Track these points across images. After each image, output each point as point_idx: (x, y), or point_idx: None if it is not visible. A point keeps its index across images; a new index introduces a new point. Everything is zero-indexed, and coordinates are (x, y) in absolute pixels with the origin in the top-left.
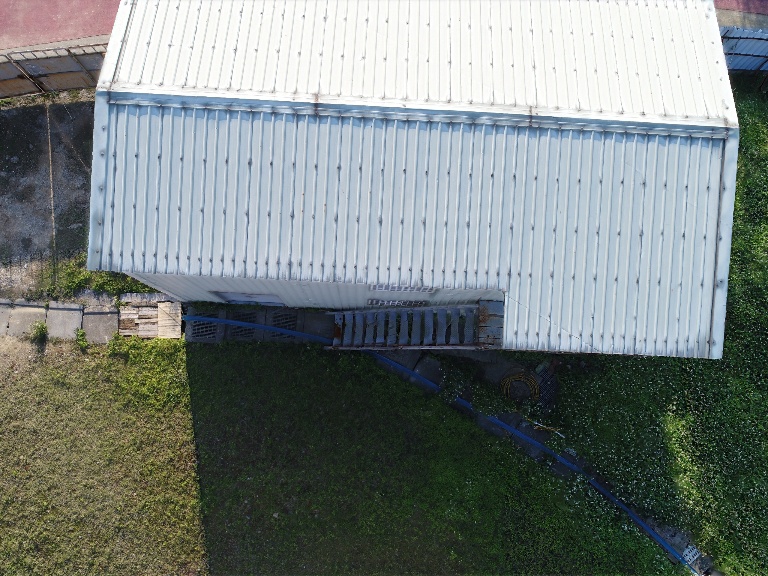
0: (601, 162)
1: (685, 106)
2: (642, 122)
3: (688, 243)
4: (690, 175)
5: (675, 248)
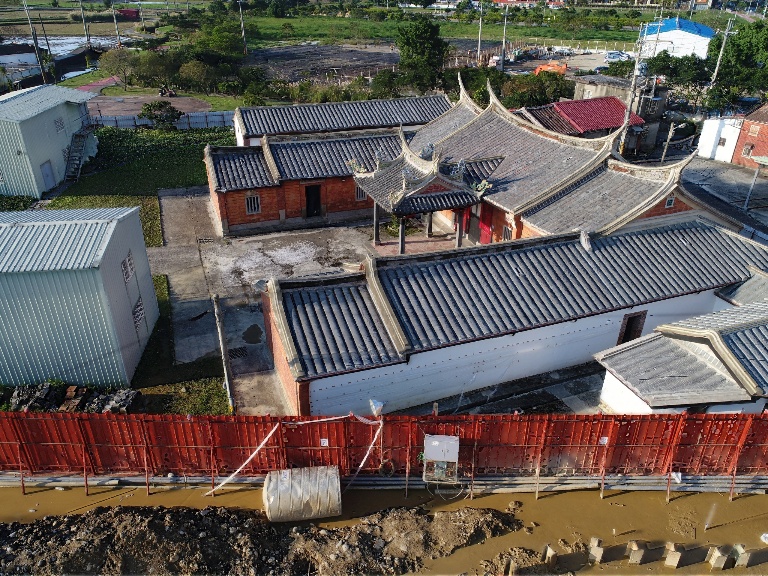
0: None
1: None
2: None
3: None
4: None
5: None
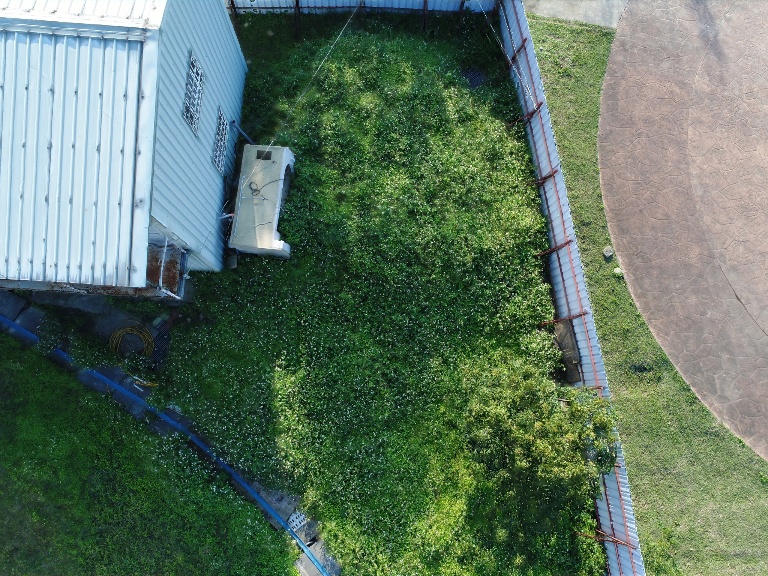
0: (2, 65)
1: (108, 6)
2: (46, 21)
3: (104, 157)
4: (105, 81)
5: (89, 163)
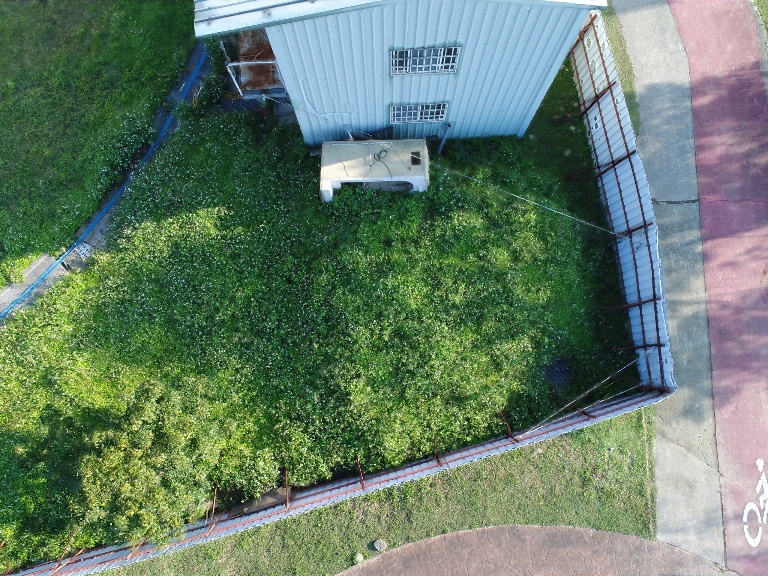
0: None
1: None
2: None
3: None
4: None
5: None
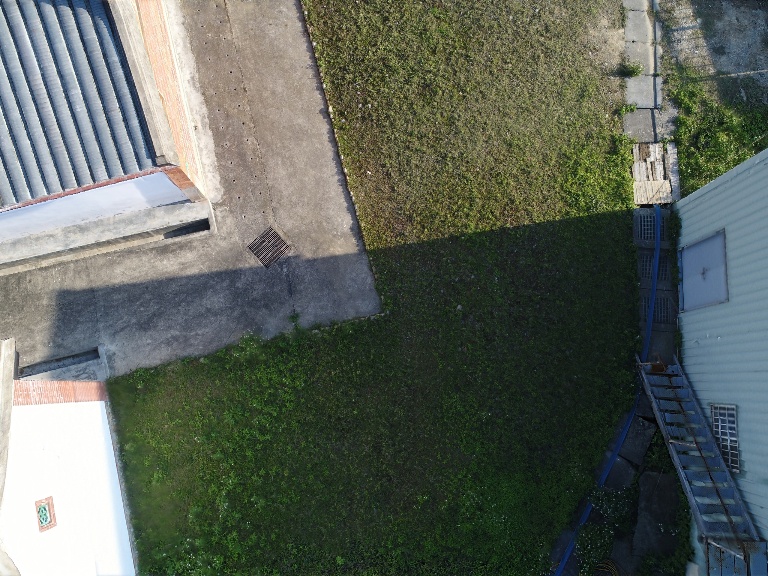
0: None
1: None
2: None
3: None
4: None
5: None
